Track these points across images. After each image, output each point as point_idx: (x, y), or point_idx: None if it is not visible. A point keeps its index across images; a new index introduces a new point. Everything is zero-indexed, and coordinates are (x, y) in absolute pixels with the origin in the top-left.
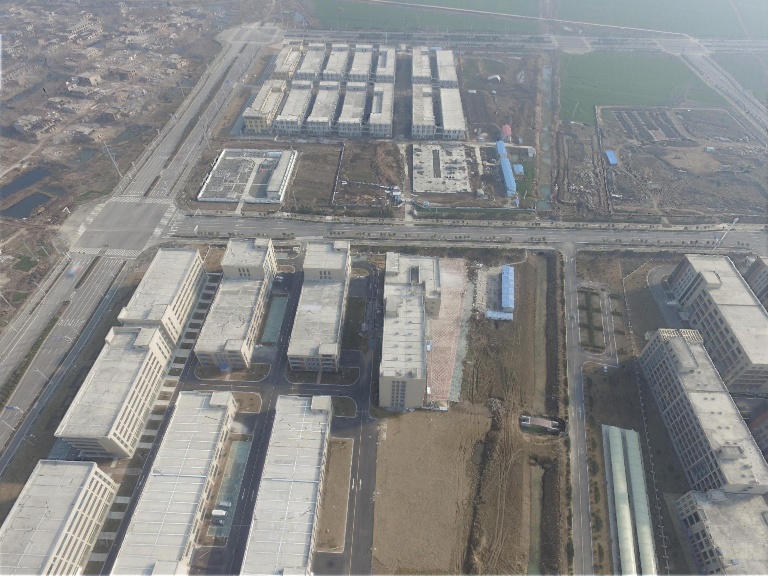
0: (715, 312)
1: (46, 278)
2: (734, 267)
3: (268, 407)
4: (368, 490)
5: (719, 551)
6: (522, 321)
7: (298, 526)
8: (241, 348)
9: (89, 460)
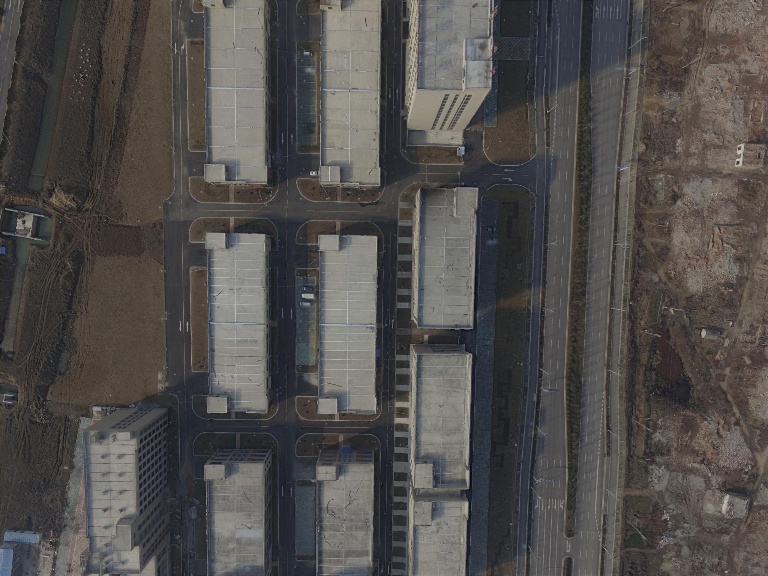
0: None
1: (616, 573)
2: None
3: (288, 404)
4: (172, 321)
5: None
6: None
7: (223, 283)
8: (317, 469)
9: (452, 341)
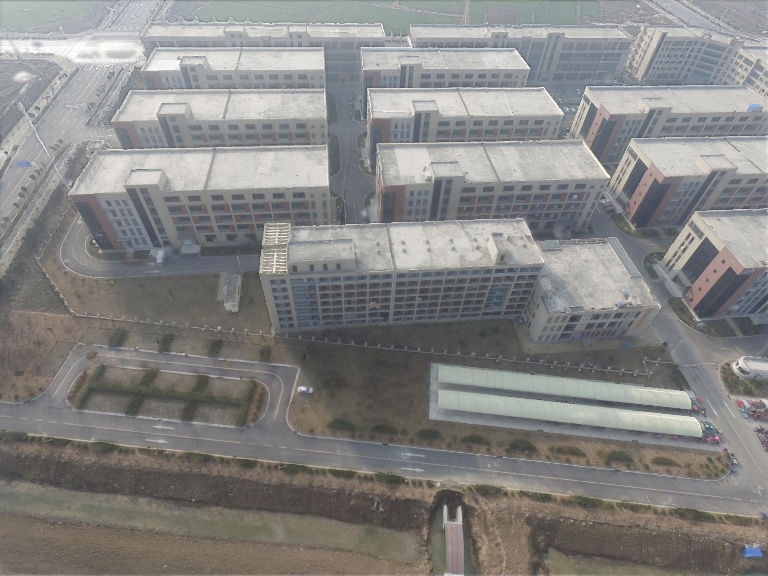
0: (217, 198)
1: None
2: (124, 151)
3: None
4: None
5: (623, 305)
6: (147, 573)
7: None
8: None
9: None
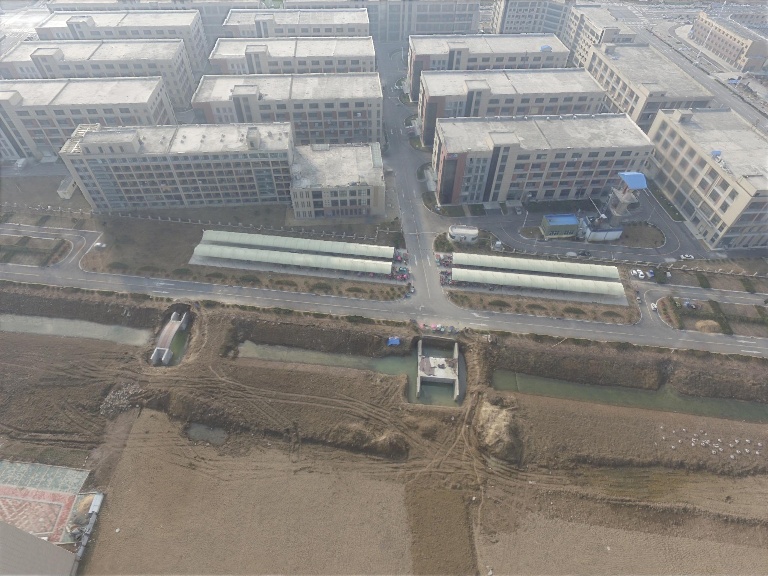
0: (59, 113)
1: None
2: None
3: None
4: None
5: (353, 183)
6: None
7: None
8: None
9: None
